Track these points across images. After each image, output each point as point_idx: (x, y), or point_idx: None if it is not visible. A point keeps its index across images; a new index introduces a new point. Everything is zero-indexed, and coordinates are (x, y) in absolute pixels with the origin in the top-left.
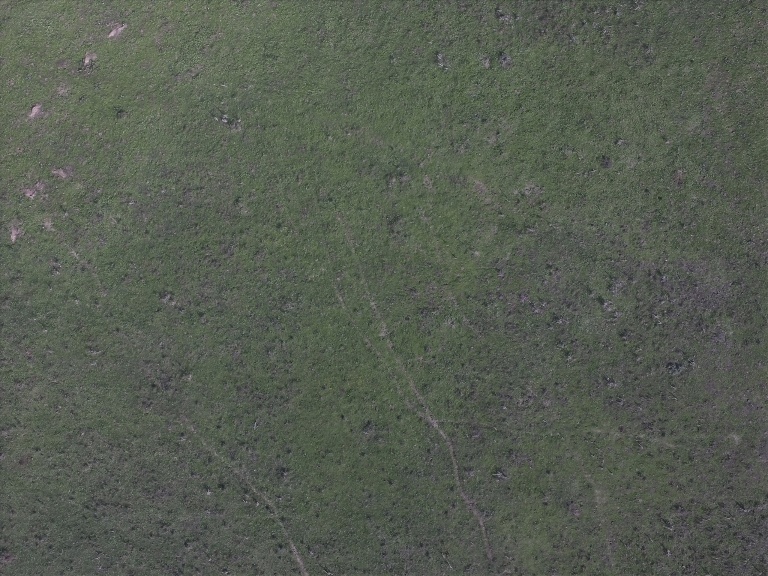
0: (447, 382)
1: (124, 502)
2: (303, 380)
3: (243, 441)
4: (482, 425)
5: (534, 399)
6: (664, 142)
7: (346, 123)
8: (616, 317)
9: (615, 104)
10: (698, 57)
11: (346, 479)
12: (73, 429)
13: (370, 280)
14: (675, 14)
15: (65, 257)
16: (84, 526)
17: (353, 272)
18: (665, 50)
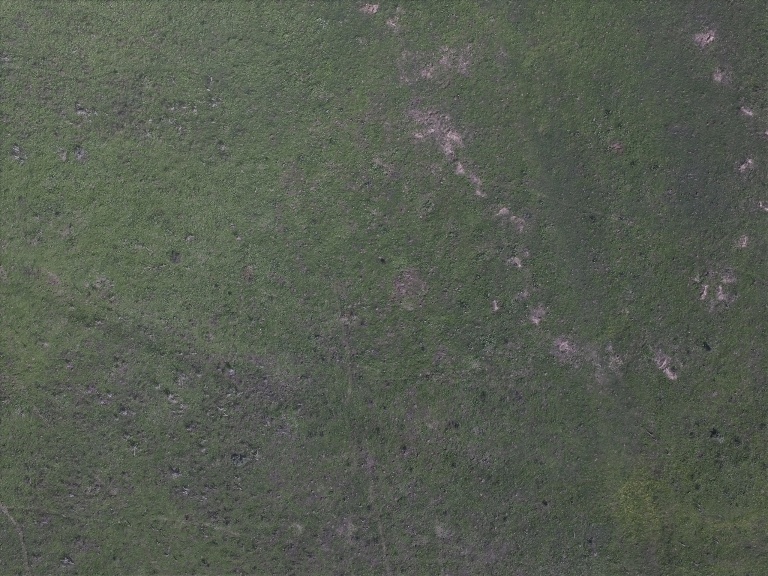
0: (17, 470)
1: None
2: None
3: None
4: (51, 512)
5: (101, 487)
6: (235, 238)
7: None
8: (182, 409)
9: (187, 200)
10: (274, 155)
11: None
12: None
13: None
14: (253, 111)
15: None
16: None
17: None
18: (241, 147)
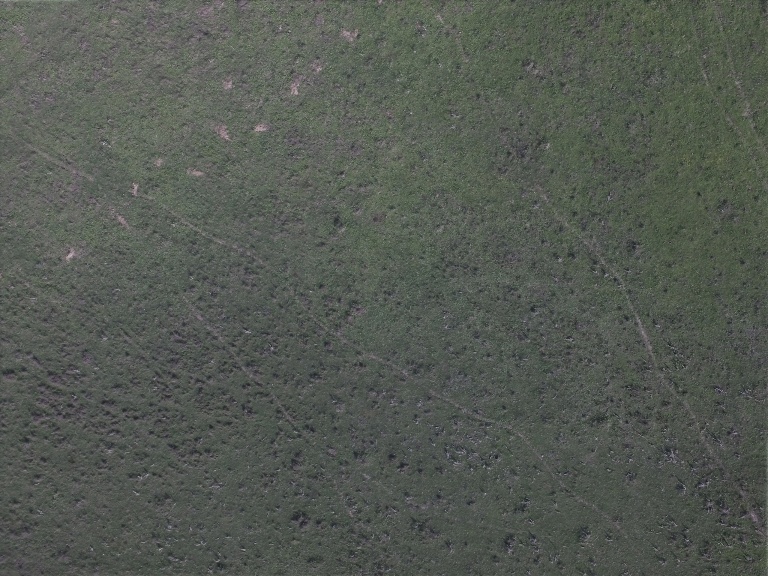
0: None
1: (473, 265)
2: (661, 155)
3: (595, 212)
4: None
5: None
6: None
7: None
8: None
9: None
10: None
11: (697, 256)
12: (428, 191)
13: (737, 59)
14: None
15: (431, 21)
16: (432, 286)
17: (720, 50)
18: None
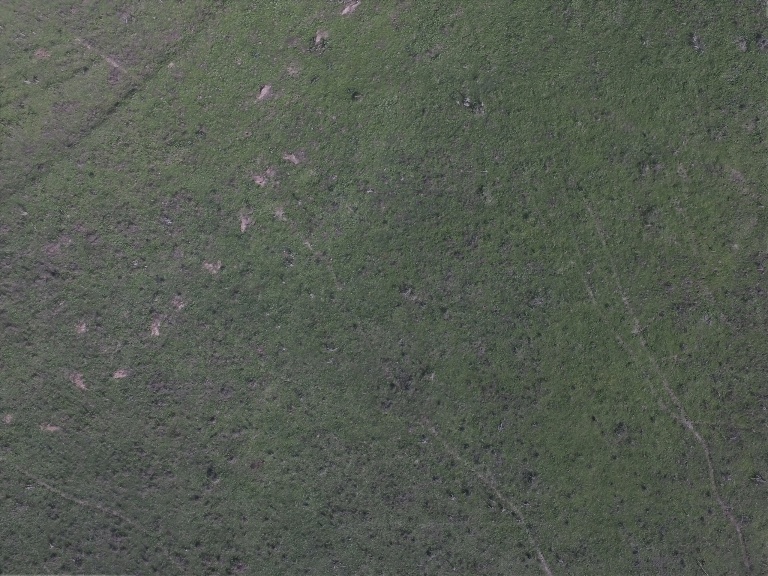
0: (703, 381)
1: (361, 508)
2: (552, 379)
3: (488, 443)
4: (740, 426)
5: None
6: None
7: (595, 108)
8: None
9: None
10: None
11: (596, 483)
12: (307, 431)
13: (622, 274)
14: None
15: (299, 248)
16: (319, 534)
17: (604, 265)
18: None
